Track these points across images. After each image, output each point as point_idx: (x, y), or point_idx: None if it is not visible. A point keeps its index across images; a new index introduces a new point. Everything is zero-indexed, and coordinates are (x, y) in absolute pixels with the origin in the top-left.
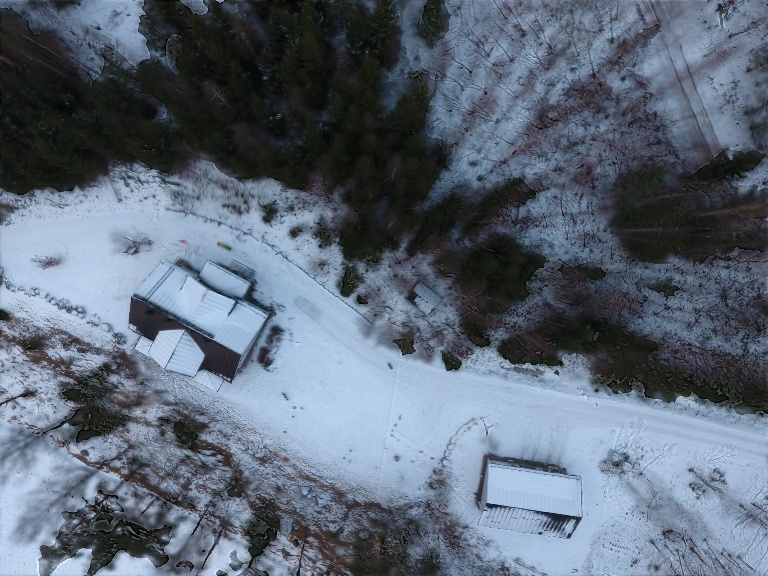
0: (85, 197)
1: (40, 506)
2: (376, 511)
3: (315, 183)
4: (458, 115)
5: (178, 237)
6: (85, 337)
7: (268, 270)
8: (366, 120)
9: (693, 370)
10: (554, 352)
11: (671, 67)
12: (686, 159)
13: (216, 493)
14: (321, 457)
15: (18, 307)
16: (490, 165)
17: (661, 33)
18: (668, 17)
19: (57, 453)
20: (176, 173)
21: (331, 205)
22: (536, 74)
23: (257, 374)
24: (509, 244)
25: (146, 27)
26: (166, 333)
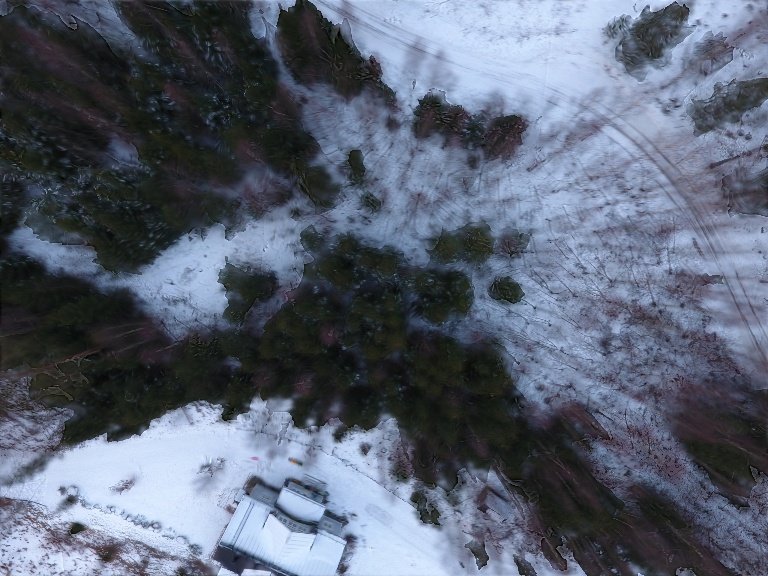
0: (158, 422)
1: None
2: None
3: None
4: (523, 345)
5: (250, 454)
6: (160, 547)
7: (339, 481)
8: (449, 397)
9: (759, 557)
10: (630, 571)
11: (728, 292)
12: (746, 373)
13: None
14: None
15: (93, 521)
16: (556, 389)
17: (717, 263)
18: (723, 248)
19: None
20: None
21: None
22: (598, 305)
23: None
24: (581, 470)
25: None
26: (252, 572)
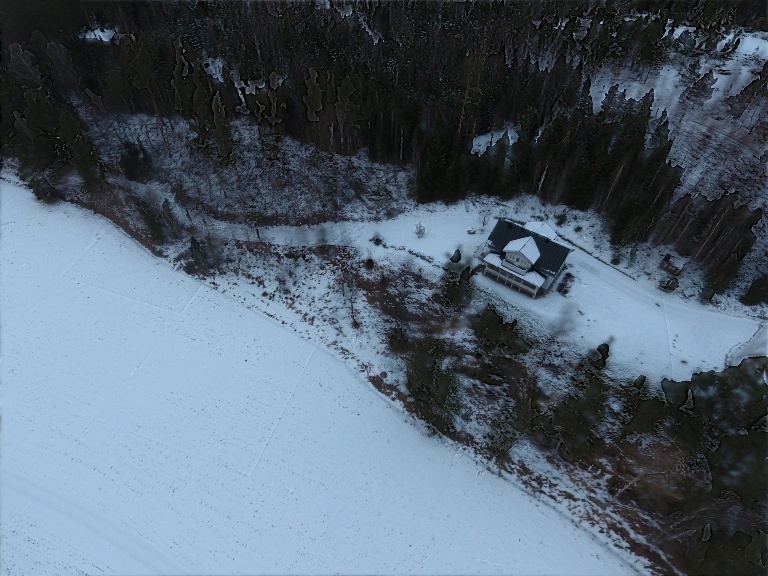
0: (447, 209)
1: (328, 418)
2: (672, 421)
3: (589, 209)
4: None
5: None
6: (427, 275)
7: None
8: (640, 151)
9: None
10: None
11: None
12: None
13: (497, 423)
14: (616, 357)
15: (385, 258)
16: None
17: None
18: None
19: (357, 376)
20: (505, 201)
21: (600, 219)
22: (710, 172)
23: (557, 298)
24: None
25: (526, 127)
26: (516, 240)
